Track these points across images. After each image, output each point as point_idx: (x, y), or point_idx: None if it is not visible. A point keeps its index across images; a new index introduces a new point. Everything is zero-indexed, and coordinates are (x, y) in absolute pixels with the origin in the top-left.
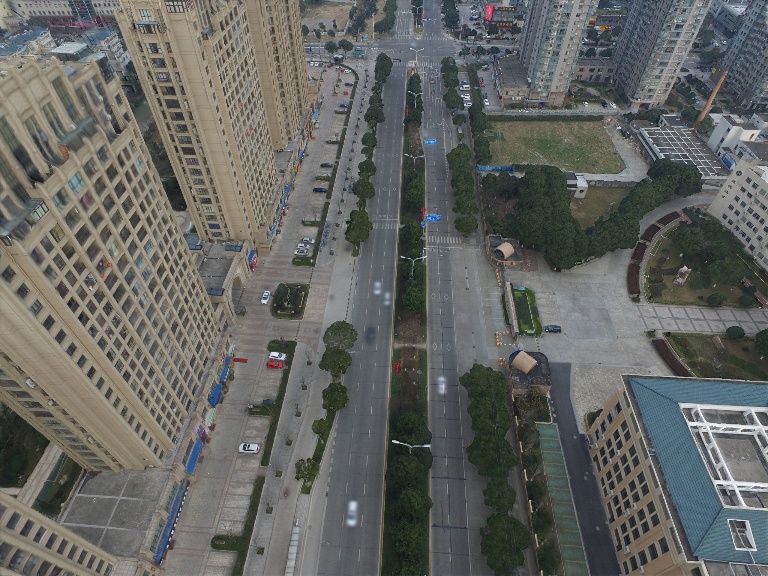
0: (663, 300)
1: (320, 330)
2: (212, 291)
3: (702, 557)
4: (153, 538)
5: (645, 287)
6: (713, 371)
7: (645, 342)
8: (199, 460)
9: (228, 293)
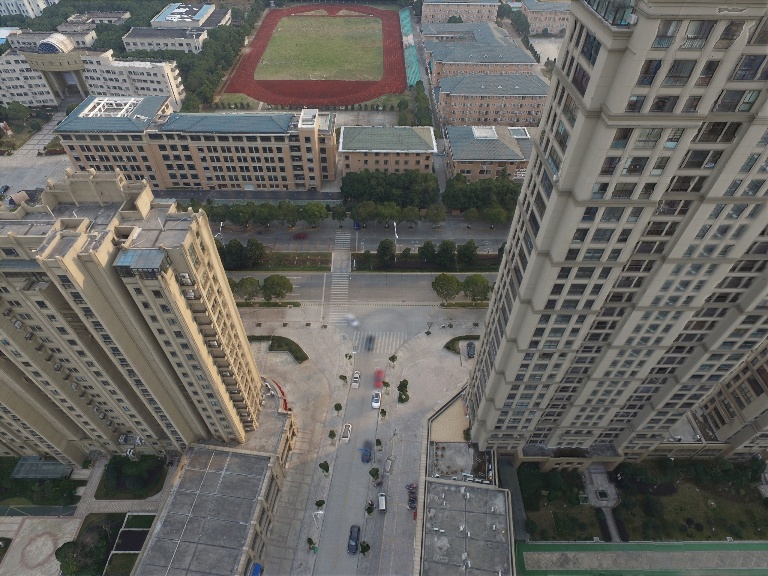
0: (19, 144)
1: None
2: None
3: (144, 129)
4: None
5: (3, 148)
6: None
7: (44, 158)
8: None
9: None
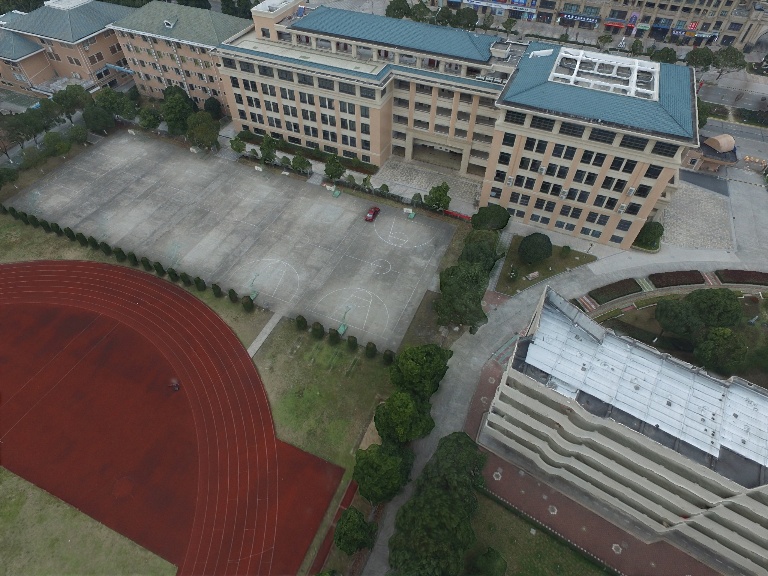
0: None
1: (738, 79)
2: (758, 5)
3: None
4: (571, 3)
5: None
6: (743, 313)
7: None
8: (614, 34)
9: (763, 24)
